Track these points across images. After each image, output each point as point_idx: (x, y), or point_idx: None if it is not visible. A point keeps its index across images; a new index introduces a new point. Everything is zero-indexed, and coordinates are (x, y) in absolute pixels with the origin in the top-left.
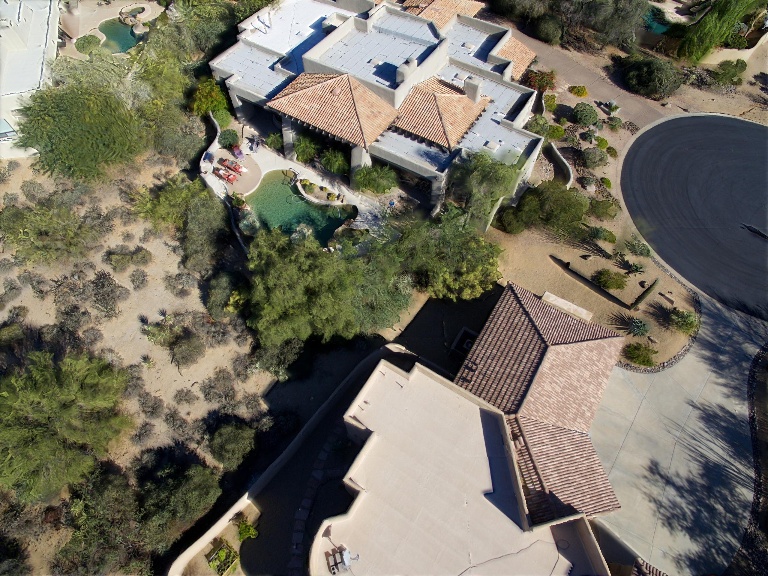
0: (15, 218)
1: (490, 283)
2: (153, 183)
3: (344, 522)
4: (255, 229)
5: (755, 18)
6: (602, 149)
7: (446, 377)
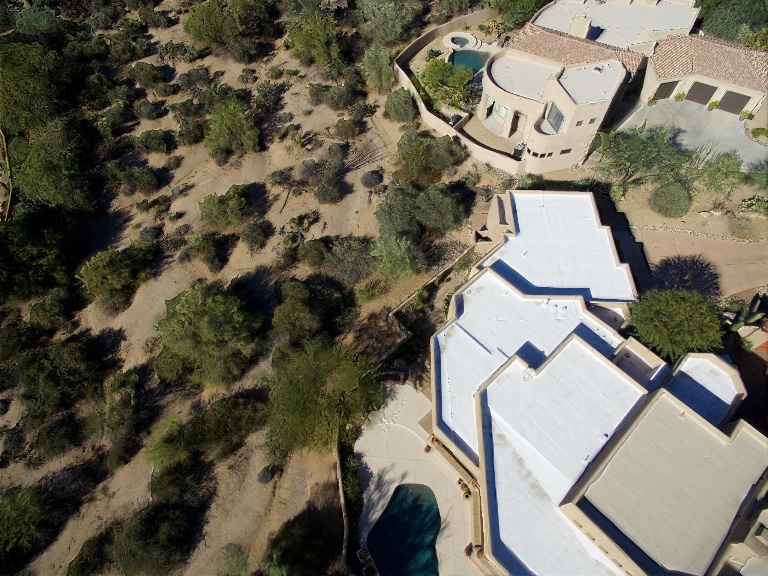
0: None
1: None
2: None
3: (615, 1)
4: None
5: None
6: None
7: None
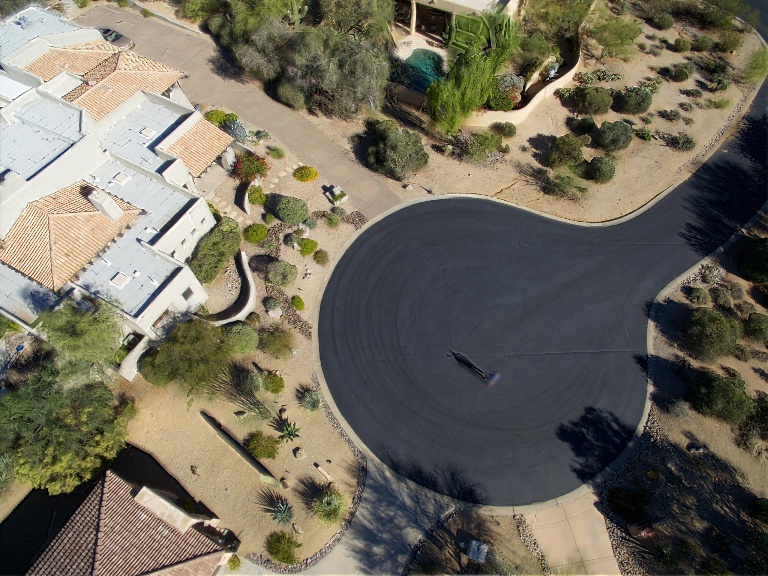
0: None
1: (92, 469)
2: None
3: None
4: None
5: (537, 68)
6: (307, 255)
7: None
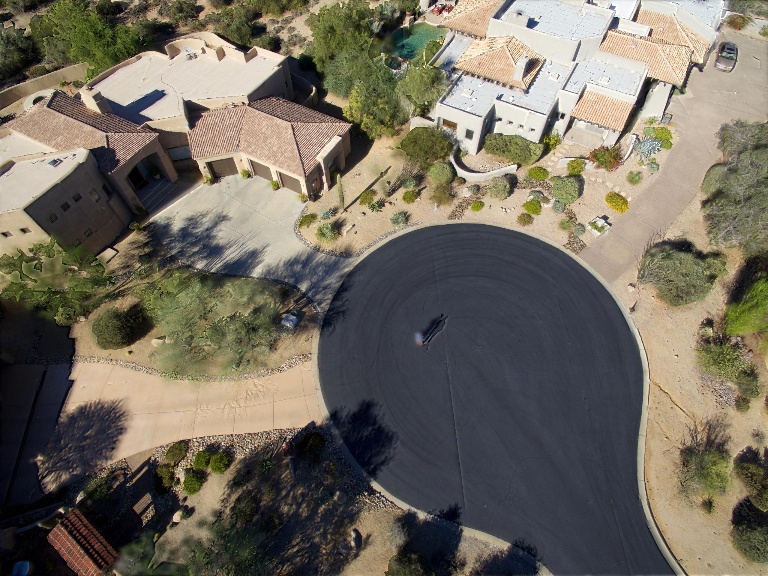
0: None
1: None
2: None
3: None
4: (382, 12)
5: None
6: None
7: None
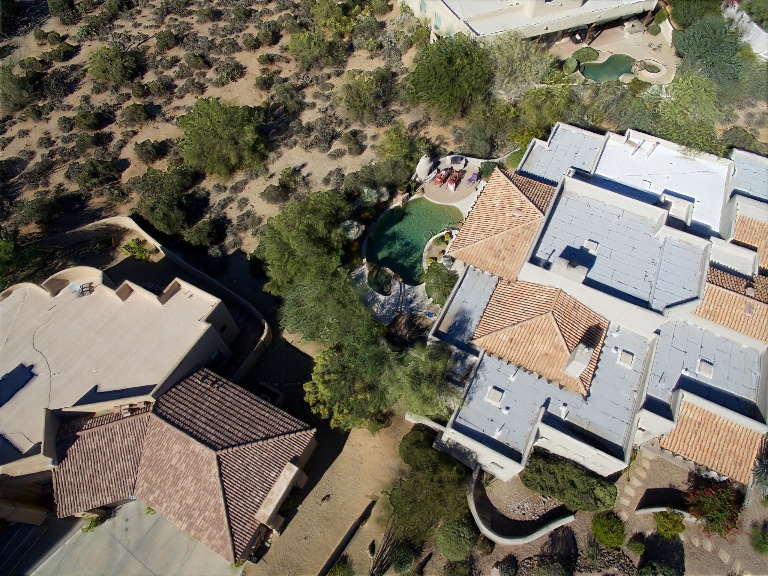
0: (382, 77)
1: None
2: (432, 137)
3: None
4: (364, 199)
5: None
6: None
7: (231, 376)
